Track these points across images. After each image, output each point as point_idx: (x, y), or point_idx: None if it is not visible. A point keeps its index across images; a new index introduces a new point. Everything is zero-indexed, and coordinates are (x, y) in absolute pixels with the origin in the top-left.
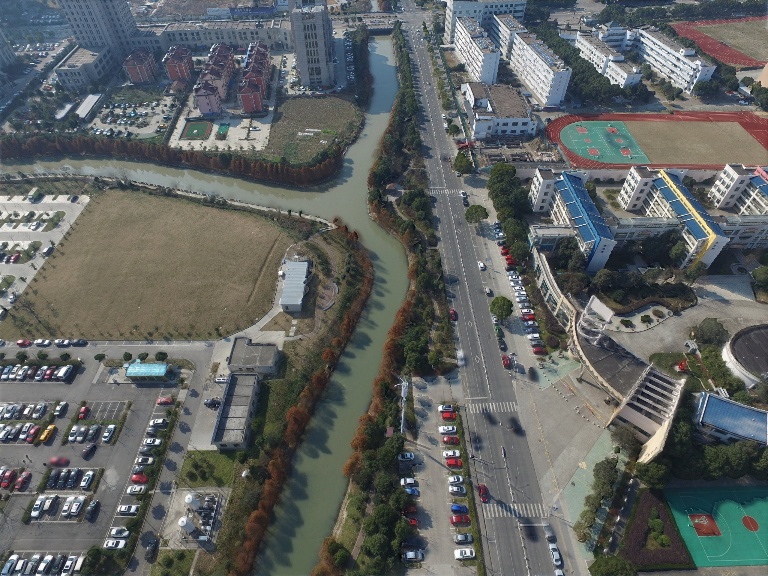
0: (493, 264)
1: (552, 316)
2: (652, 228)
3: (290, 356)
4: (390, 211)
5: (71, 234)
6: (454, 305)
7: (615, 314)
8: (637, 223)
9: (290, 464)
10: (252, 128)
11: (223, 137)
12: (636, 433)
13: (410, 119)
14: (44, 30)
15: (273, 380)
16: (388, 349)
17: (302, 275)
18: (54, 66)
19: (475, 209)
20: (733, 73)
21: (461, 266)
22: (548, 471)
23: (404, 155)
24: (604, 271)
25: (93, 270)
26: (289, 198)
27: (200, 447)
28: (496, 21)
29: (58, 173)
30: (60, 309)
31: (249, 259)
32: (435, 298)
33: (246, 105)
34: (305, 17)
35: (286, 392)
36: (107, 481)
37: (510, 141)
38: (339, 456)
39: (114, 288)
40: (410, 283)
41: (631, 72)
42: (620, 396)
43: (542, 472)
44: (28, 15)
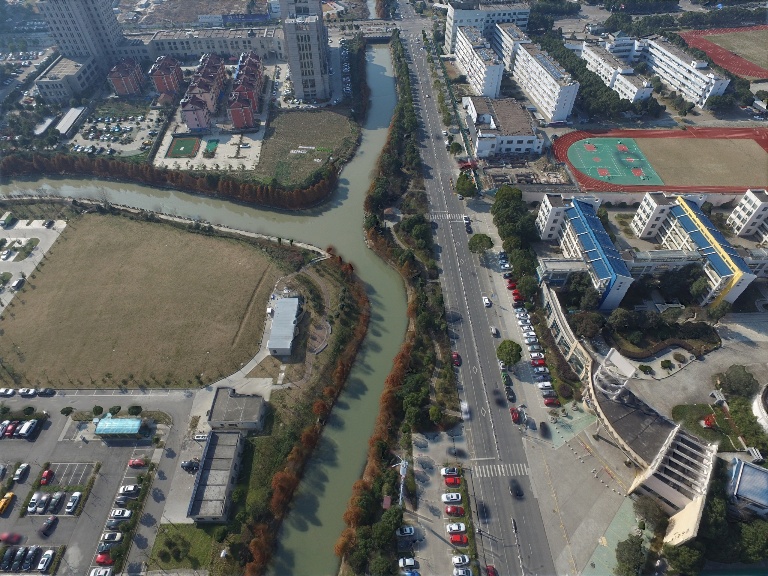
0: (499, 300)
1: (564, 361)
2: (671, 262)
3: (277, 408)
4: (388, 239)
5: (44, 265)
6: (457, 347)
7: (633, 358)
8: (655, 257)
9: (275, 539)
10: (242, 145)
11: (211, 155)
12: (662, 504)
13: (409, 135)
14: (28, 38)
15: (258, 437)
16: (385, 402)
17: (292, 314)
18: (36, 77)
19: (479, 239)
20: (747, 86)
21: (464, 302)
22: (564, 549)
23: (403, 175)
24: (620, 311)
25: (65, 307)
26: (280, 221)
27: (175, 519)
28: (498, 30)
29: (35, 194)
30: (27, 352)
31: (235, 294)
32: (436, 339)
33: (236, 120)
34: (298, 28)
35: (272, 452)
36: (68, 562)
37: (515, 160)
38: (330, 530)
39: (87, 328)
40: (409, 321)
41: (641, 86)
42: (644, 463)
43: (558, 550)
44: (13, 21)
